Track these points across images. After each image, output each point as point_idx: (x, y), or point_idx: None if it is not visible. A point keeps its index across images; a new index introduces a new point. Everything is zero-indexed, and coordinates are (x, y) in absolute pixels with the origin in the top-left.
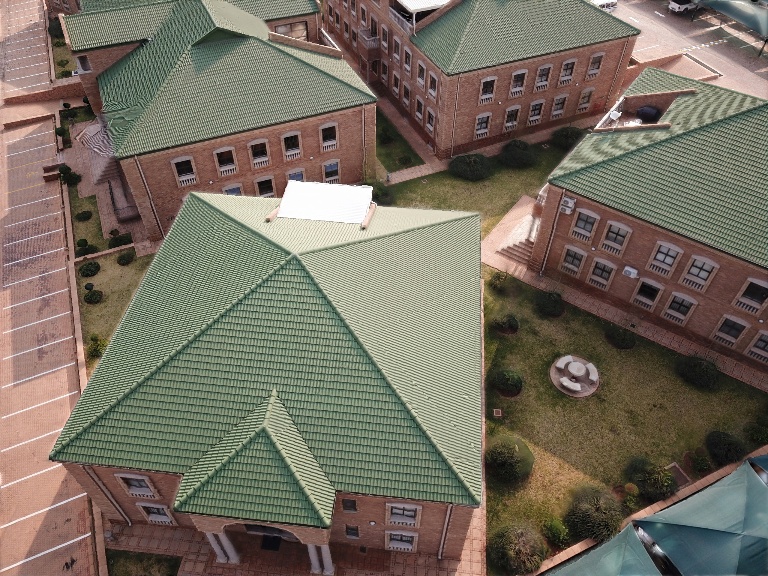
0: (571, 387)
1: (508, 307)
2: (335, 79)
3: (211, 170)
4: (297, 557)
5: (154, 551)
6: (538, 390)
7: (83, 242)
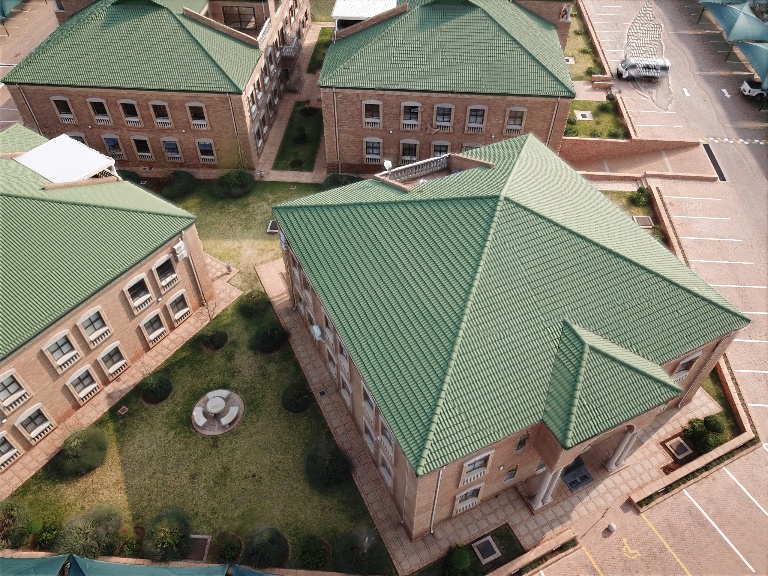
0: (195, 419)
1: (235, 325)
2: (214, 63)
3: (88, 116)
4: None
5: None
6: (175, 408)
7: None
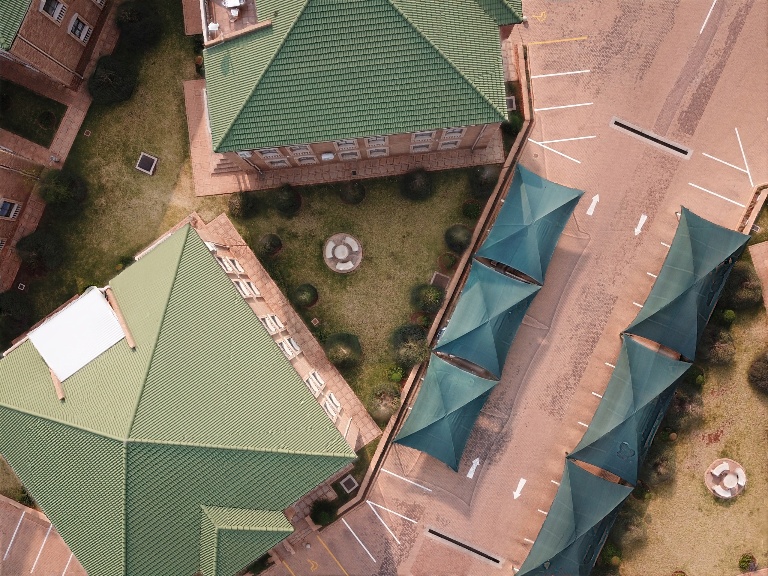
0: (346, 269)
1: (260, 226)
2: None
3: None
4: None
5: None
6: (328, 284)
7: None
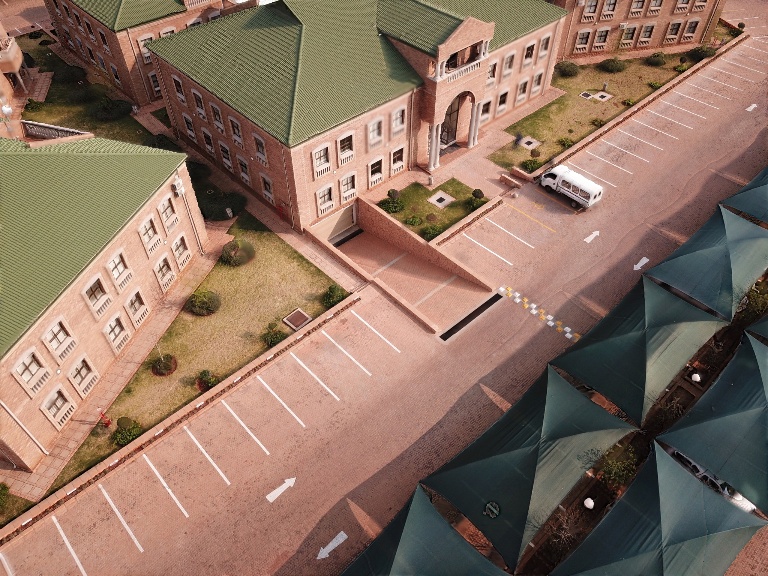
0: None
1: None
2: (121, 1)
3: None
4: None
5: None
6: None
7: None
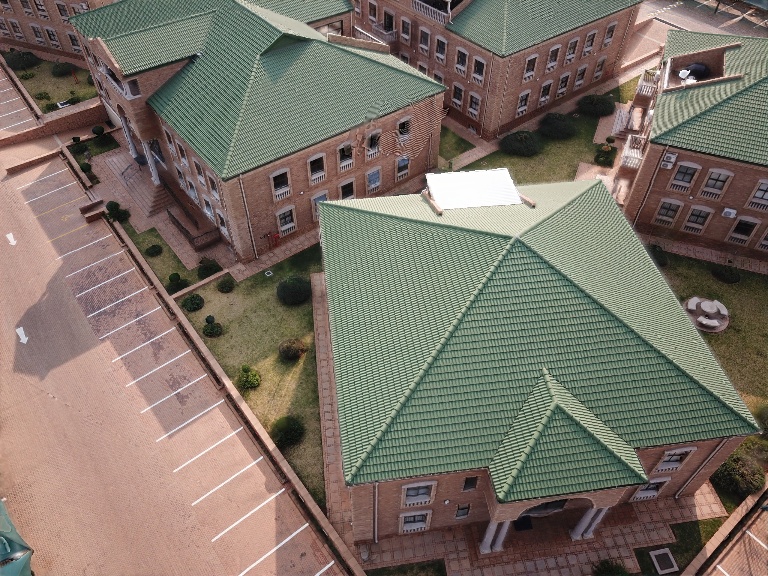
0: (711, 324)
1: None
2: (403, 73)
3: (303, 180)
4: (553, 530)
5: (413, 560)
6: None
7: (177, 276)
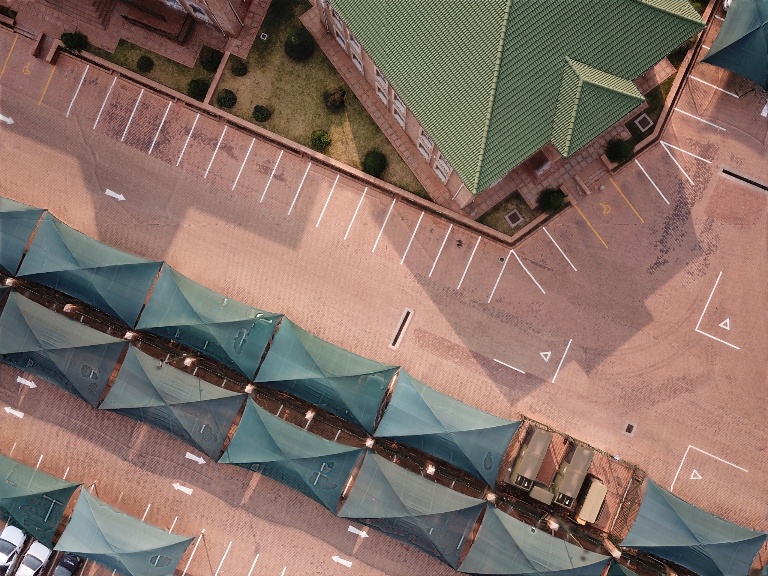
0: None
1: None
2: None
3: None
4: None
5: (499, 200)
6: None
7: (196, 83)
